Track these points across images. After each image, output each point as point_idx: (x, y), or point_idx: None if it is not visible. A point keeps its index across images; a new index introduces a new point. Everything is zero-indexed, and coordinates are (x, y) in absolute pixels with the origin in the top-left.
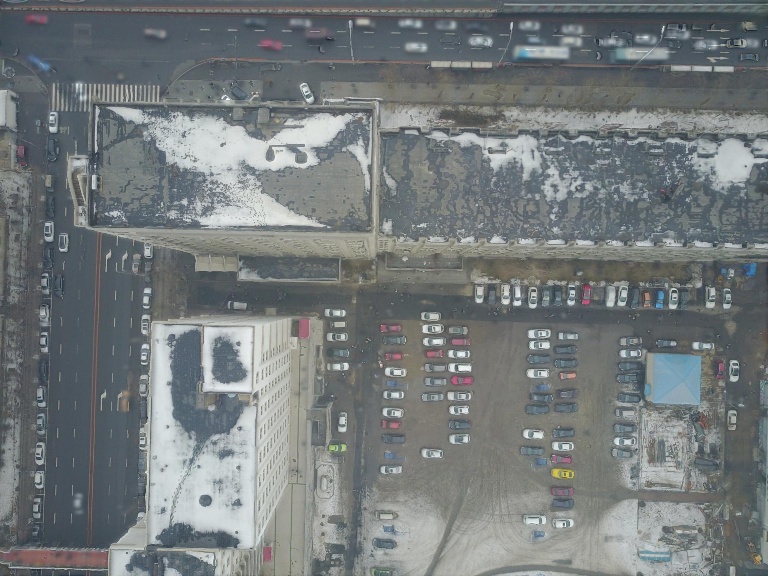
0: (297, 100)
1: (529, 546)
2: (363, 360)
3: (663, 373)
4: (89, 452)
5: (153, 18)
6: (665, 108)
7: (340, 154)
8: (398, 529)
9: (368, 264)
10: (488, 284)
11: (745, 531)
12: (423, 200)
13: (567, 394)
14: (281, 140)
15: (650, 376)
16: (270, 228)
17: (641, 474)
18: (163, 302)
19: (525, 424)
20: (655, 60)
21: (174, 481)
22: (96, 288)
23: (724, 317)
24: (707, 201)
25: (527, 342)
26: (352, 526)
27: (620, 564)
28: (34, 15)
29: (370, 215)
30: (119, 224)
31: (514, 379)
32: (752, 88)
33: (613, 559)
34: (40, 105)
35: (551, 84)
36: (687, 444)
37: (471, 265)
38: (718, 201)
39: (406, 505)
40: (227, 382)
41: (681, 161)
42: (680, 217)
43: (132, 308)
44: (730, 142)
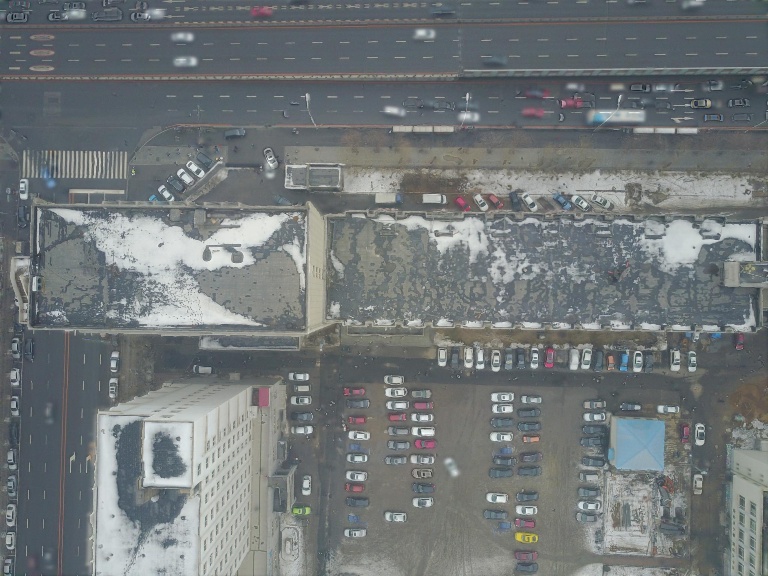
0: (261, 165)
1: None
2: (327, 423)
3: (626, 439)
4: (59, 514)
5: (120, 85)
6: (628, 170)
7: (276, 253)
8: None
9: (332, 327)
10: (451, 347)
11: None
12: (370, 283)
13: (530, 458)
14: (218, 240)
15: (614, 441)
16: (207, 327)
17: (606, 538)
18: (130, 365)
19: (489, 487)
20: (618, 121)
21: (120, 570)
22: (65, 352)
23: (690, 380)
24: (655, 283)
25: (490, 405)
26: None
27: None
28: (5, 84)
29: (305, 314)
30: (60, 323)
31: (478, 442)
32: (717, 149)
33: None
34: (11, 172)
35: (514, 146)
36: (652, 508)
37: None
38: (666, 283)
39: (370, 568)
40: (167, 477)
41: (628, 243)
42: (628, 299)
43: (100, 371)
44: (678, 223)
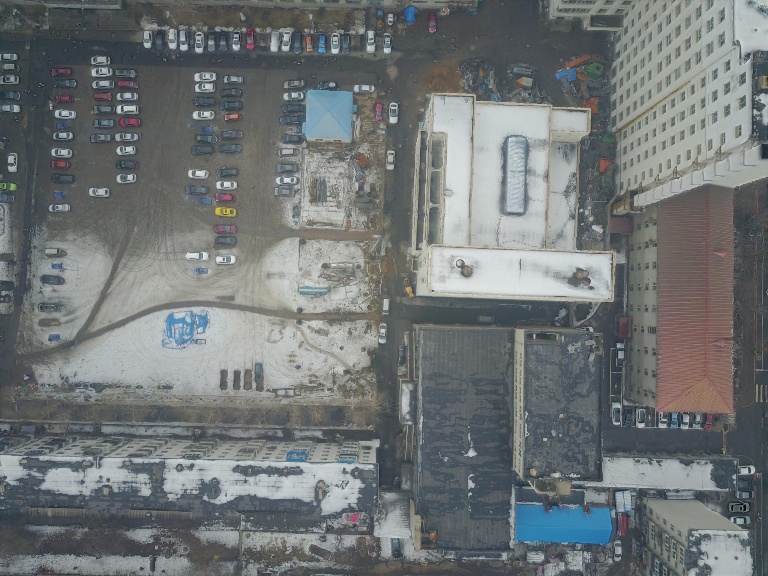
0: None
1: (193, 283)
2: (36, 104)
3: (313, 106)
4: None
5: None
6: None
7: None
8: (66, 266)
9: (41, 11)
10: (157, 30)
11: (403, 268)
12: None
13: (229, 134)
14: None
15: None
16: None
17: (303, 213)
18: None
19: (191, 165)
20: None
21: None
22: None
23: (386, 62)
24: None
25: (194, 86)
26: (22, 264)
27: (281, 300)
28: None
29: None
30: None
31: (182, 122)
32: None
33: (275, 295)
34: None
35: None
36: (348, 184)
37: (140, 12)
38: None
39: (75, 243)
40: None
41: None
42: None
43: None
44: None
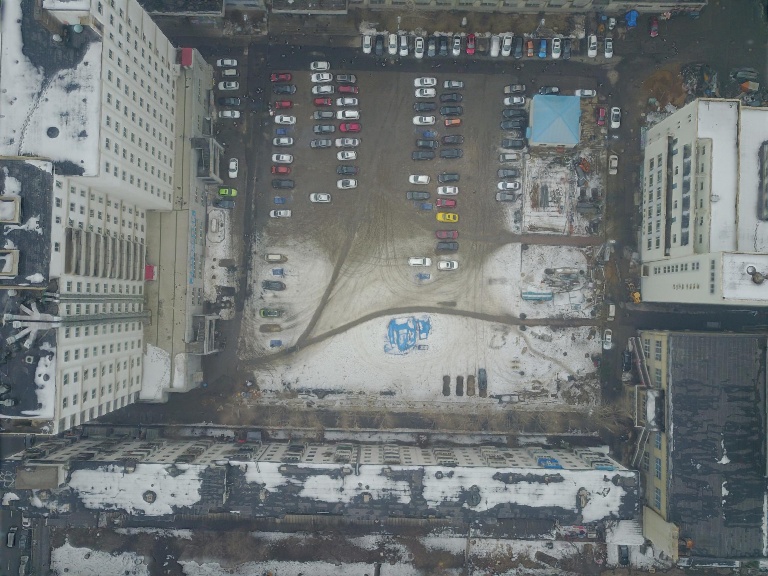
0: None
1: (415, 288)
2: (254, 110)
3: (542, 111)
4: None
5: None
6: None
7: None
8: (287, 272)
9: (260, 17)
10: (376, 36)
11: (626, 274)
12: None
13: (451, 139)
14: None
15: (532, 119)
16: None
17: (524, 218)
18: None
19: (412, 171)
20: None
21: (23, 114)
22: None
23: (606, 67)
24: None
25: (414, 91)
26: (242, 269)
27: (504, 306)
28: None
29: None
30: None
31: (401, 127)
32: None
33: (497, 301)
34: None
35: None
36: (570, 189)
37: (359, 17)
38: None
39: (295, 249)
40: (67, 1)
41: None
42: None
43: None
44: None
